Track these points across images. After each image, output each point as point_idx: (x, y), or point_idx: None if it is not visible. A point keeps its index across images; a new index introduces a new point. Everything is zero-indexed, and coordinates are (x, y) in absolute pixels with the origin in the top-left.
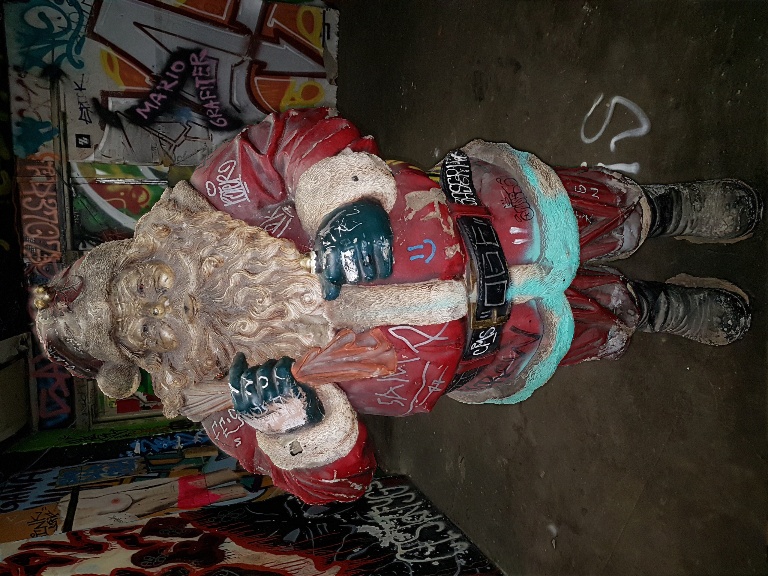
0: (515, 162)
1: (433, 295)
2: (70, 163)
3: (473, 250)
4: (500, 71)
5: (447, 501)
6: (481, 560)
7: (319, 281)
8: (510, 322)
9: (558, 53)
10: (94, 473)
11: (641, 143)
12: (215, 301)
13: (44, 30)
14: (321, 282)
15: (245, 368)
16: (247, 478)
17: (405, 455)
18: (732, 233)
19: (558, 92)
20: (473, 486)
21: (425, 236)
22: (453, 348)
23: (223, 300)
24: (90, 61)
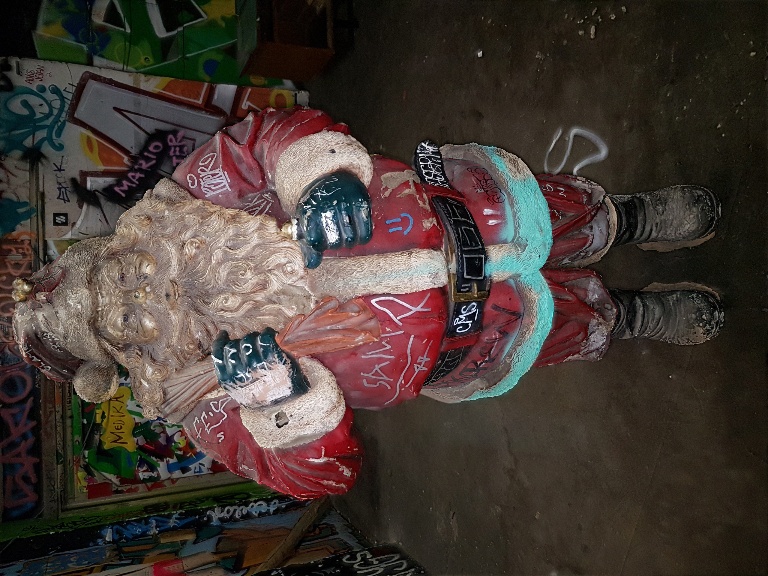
0: (484, 154)
1: (413, 261)
2: (47, 241)
3: (449, 224)
4: (464, 124)
5: (441, 564)
6: None
7: (301, 252)
8: (490, 300)
9: (517, 100)
10: (62, 564)
11: (601, 168)
12: (197, 282)
13: (26, 116)
14: (303, 251)
15: (228, 342)
16: (227, 559)
17: (394, 521)
18: (695, 231)
19: (520, 134)
20: (467, 542)
21: (402, 211)
22: (436, 321)
23: (205, 279)
24: (70, 144)
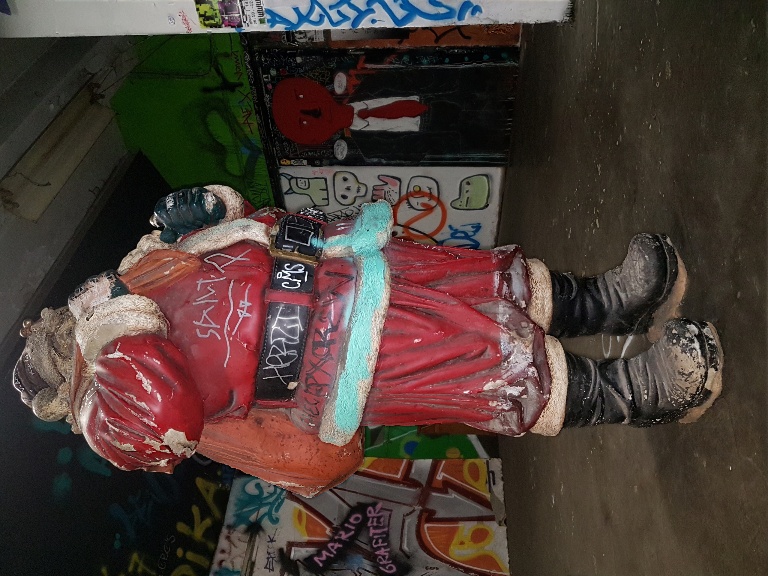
0: None
1: None
2: None
3: None
4: None
5: None
6: None
7: None
8: (324, 268)
9: None
10: None
11: None
12: None
13: (256, 496)
14: None
15: None
16: None
17: None
18: (646, 266)
19: (588, 345)
20: None
21: None
22: (255, 269)
23: None
24: (284, 517)
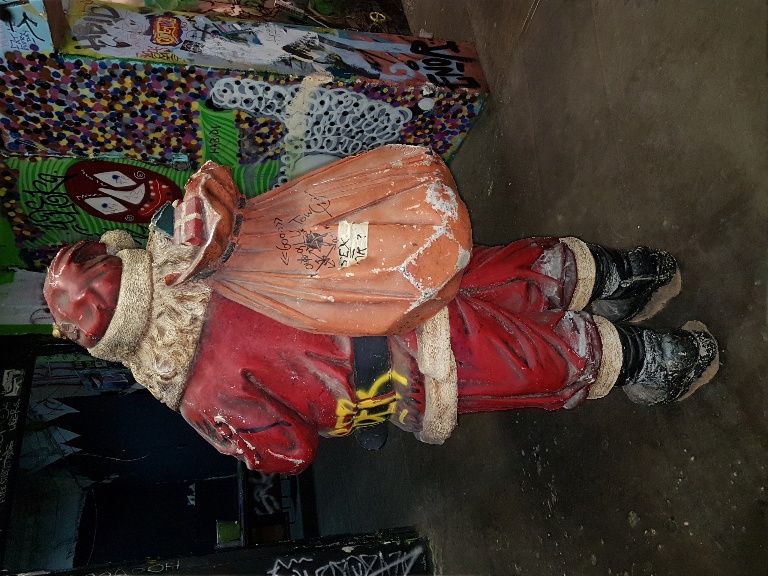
0: None
1: None
2: None
3: None
4: None
5: None
6: None
7: None
8: None
9: None
10: None
11: None
12: None
13: None
14: None
15: None
16: None
17: None
18: None
19: None
20: None
21: None
22: None
23: None
24: None
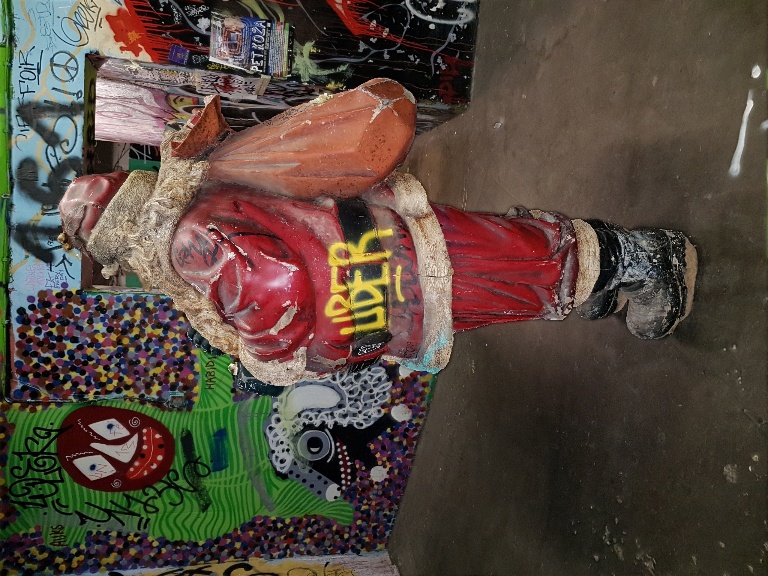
0: (428, 346)
1: None
2: None
3: (348, 371)
4: None
5: None
6: (469, 43)
7: None
8: None
9: None
10: None
11: (759, 175)
12: None
13: None
14: None
15: None
16: None
17: None
18: None
19: None
20: None
21: None
22: None
23: None
24: None
